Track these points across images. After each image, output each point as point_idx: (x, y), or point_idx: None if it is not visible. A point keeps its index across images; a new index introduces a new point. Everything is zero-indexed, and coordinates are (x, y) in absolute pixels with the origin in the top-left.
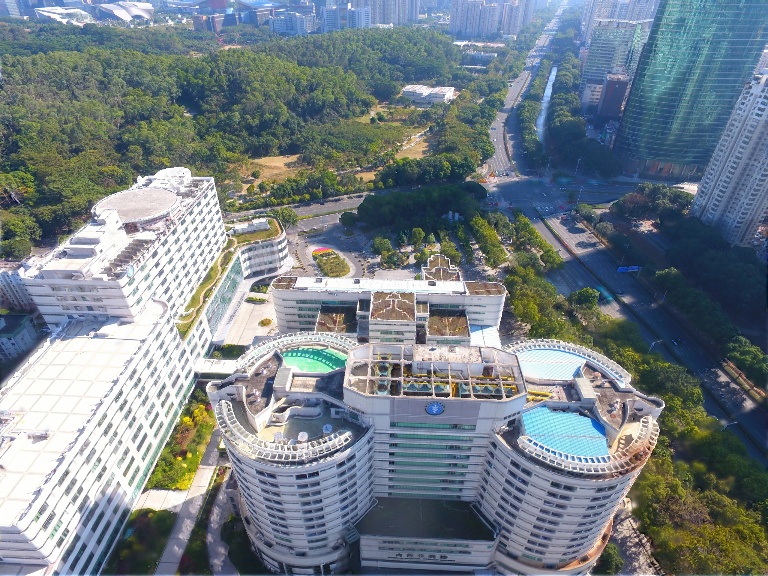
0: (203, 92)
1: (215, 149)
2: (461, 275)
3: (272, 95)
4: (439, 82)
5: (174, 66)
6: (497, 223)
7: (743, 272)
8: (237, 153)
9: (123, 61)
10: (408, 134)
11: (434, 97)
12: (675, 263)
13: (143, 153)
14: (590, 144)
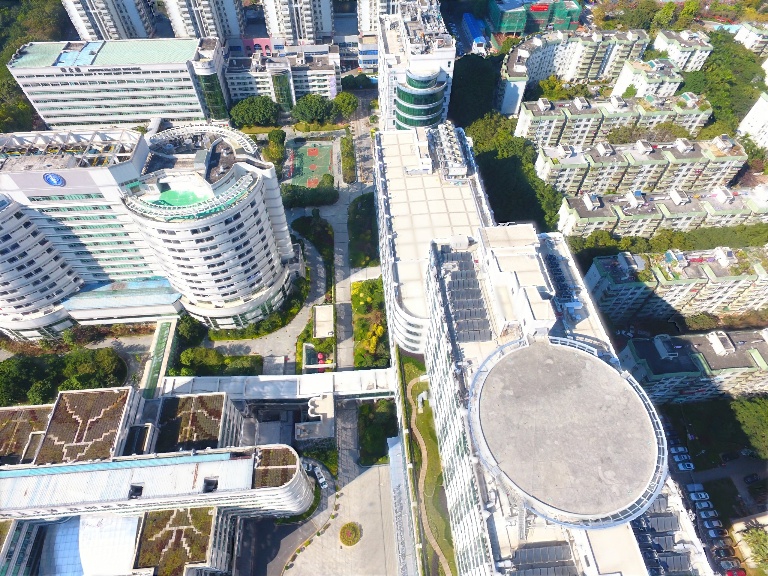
0: None
1: None
2: None
3: None
4: None
5: None
6: None
7: None
8: None
9: None
10: None
11: None
12: None
13: None
14: None
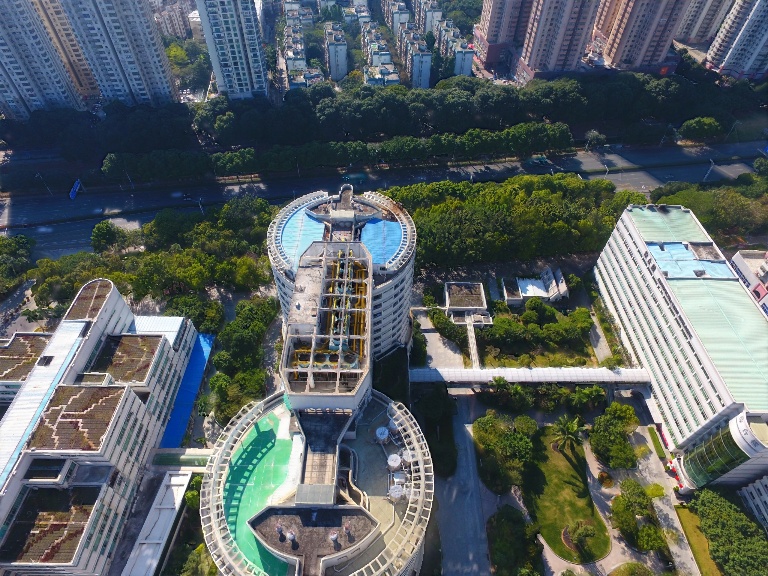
0: None
1: None
2: None
3: None
4: None
5: None
6: None
7: (142, 119)
8: None
9: None
10: None
11: None
12: (86, 156)
13: None
14: None
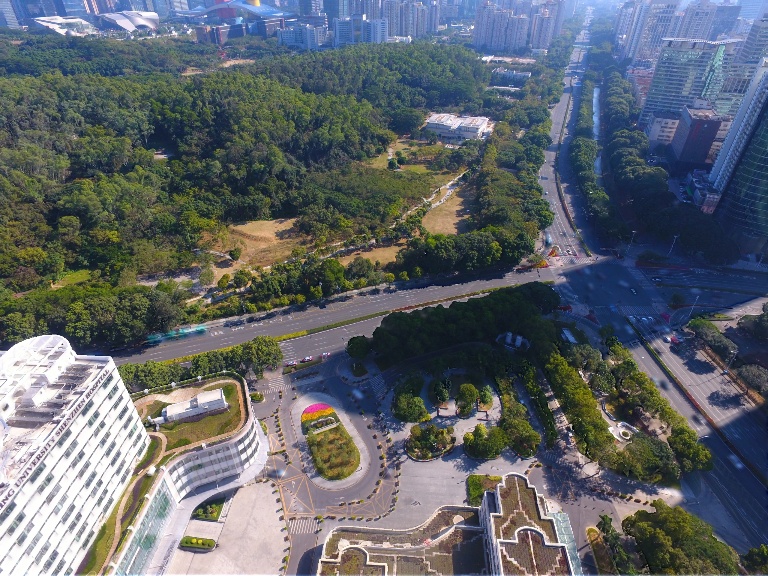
0: (182, 128)
1: (182, 217)
2: (542, 477)
3: (264, 137)
4: (469, 109)
5: (148, 96)
6: (588, 367)
7: None
8: (213, 219)
9: (84, 90)
10: (436, 184)
11: (465, 131)
12: None
13: (85, 223)
14: (689, 213)
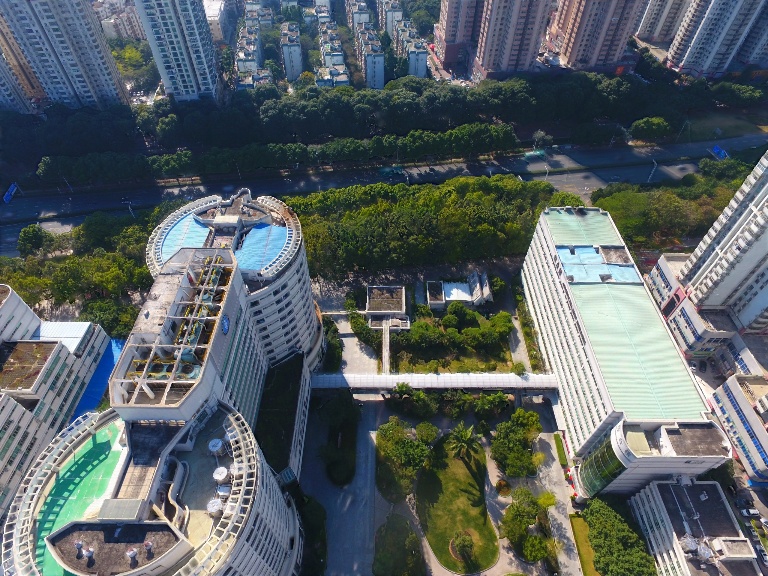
0: None
1: None
2: None
3: None
4: None
5: None
6: None
7: (82, 122)
8: None
9: None
10: None
11: None
12: (26, 160)
13: None
14: None
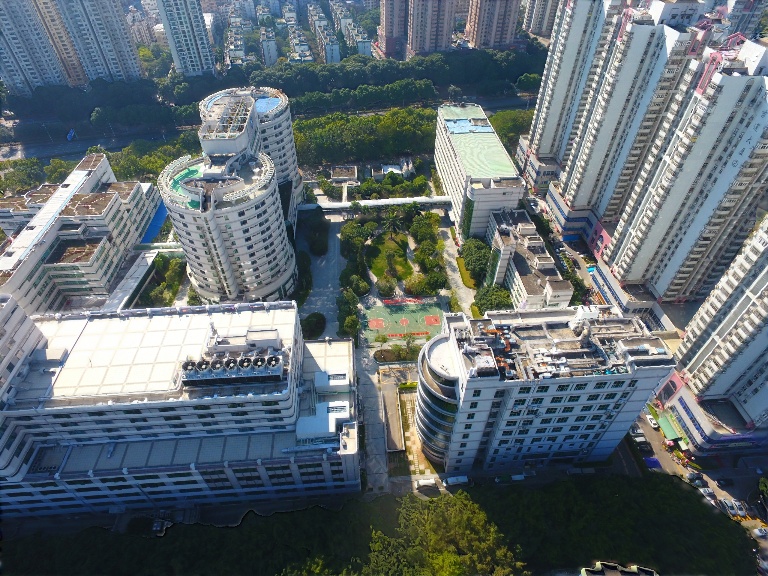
0: None
1: None
2: None
3: None
4: None
5: None
6: None
7: (119, 88)
8: None
9: None
10: None
11: None
12: (77, 117)
13: None
14: None
